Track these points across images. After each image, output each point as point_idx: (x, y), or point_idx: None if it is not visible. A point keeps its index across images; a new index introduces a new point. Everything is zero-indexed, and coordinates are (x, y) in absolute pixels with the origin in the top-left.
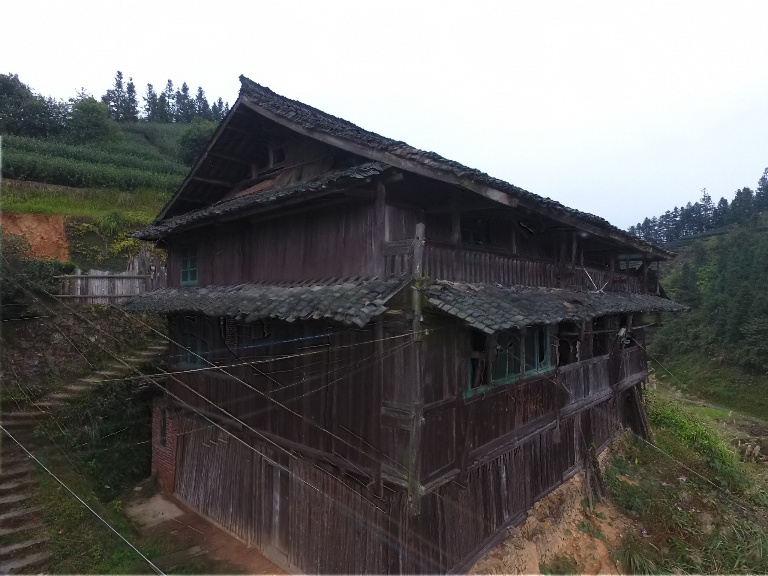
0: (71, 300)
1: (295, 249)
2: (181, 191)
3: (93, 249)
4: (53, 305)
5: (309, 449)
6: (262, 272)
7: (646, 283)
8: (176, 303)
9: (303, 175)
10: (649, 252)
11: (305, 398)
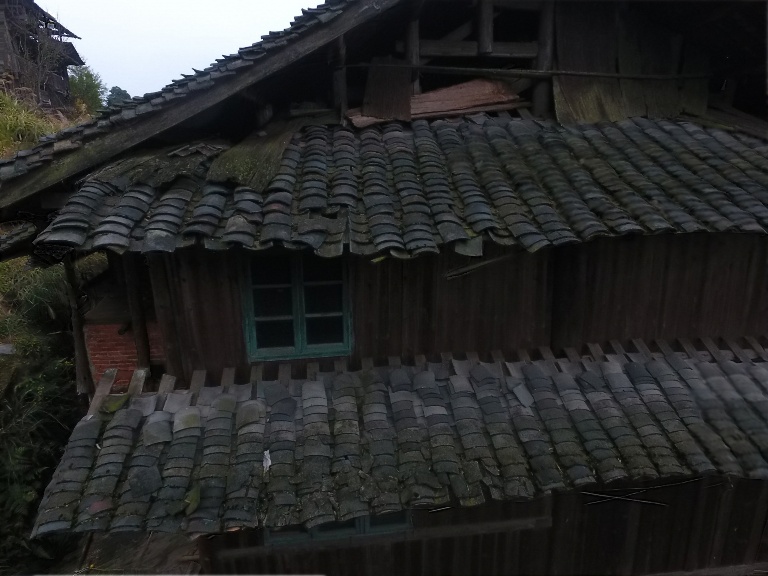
0: None
1: (737, 281)
2: (274, 68)
3: None
4: None
5: (726, 570)
6: (630, 322)
7: None
8: (510, 455)
9: (628, 103)
10: None
11: (724, 510)
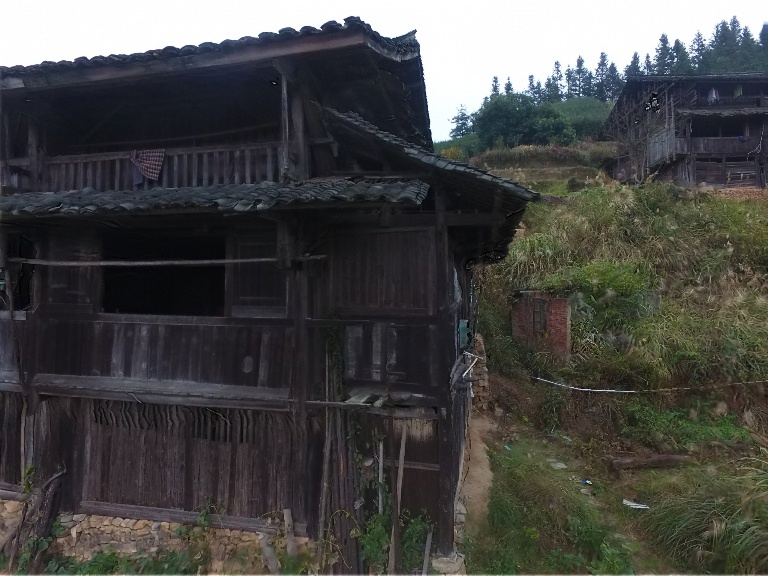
0: None
1: None
2: None
3: None
4: None
5: None
6: None
7: (293, 150)
8: None
9: None
10: (23, 89)
11: None
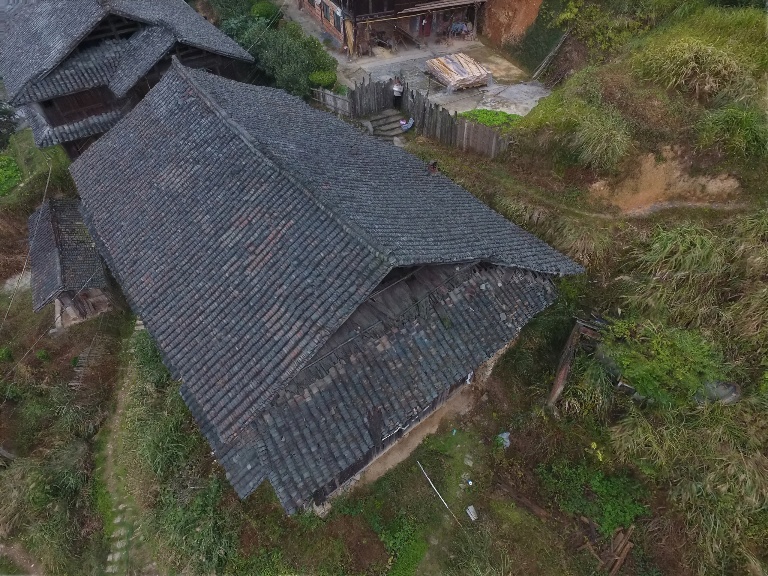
0: (319, 102)
1: None
2: None
3: (550, 14)
4: (313, 102)
5: None
6: None
7: None
8: None
9: None
10: None
11: None
